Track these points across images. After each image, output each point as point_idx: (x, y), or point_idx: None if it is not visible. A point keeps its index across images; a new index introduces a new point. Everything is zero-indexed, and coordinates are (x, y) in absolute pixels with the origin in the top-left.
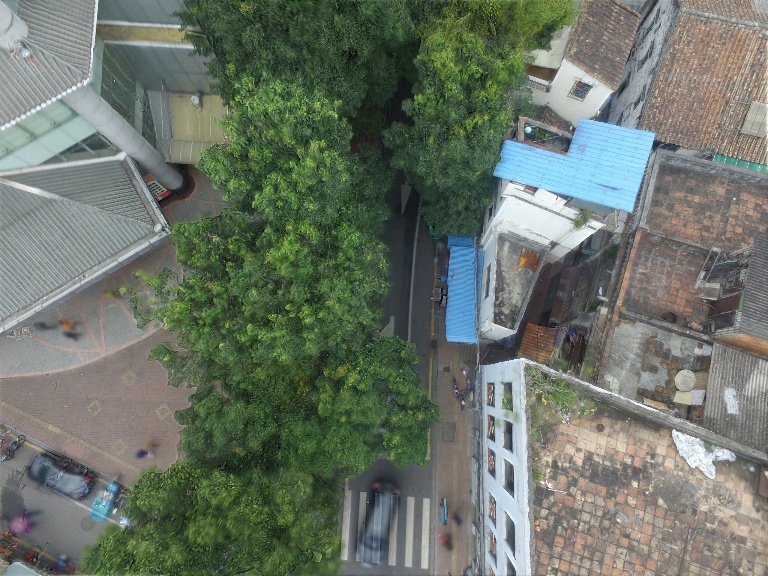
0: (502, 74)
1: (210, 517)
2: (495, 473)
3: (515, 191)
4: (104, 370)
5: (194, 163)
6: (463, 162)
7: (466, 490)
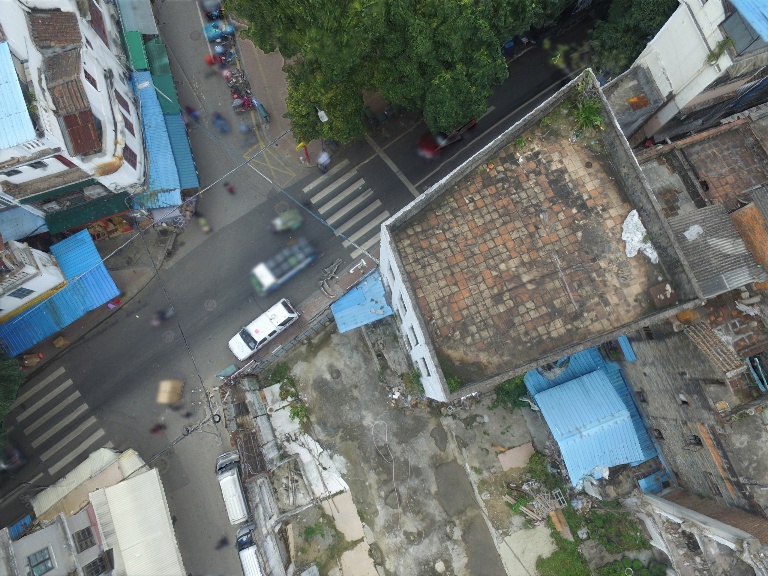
0: None
1: None
2: None
3: None
4: None
5: None
6: None
7: None
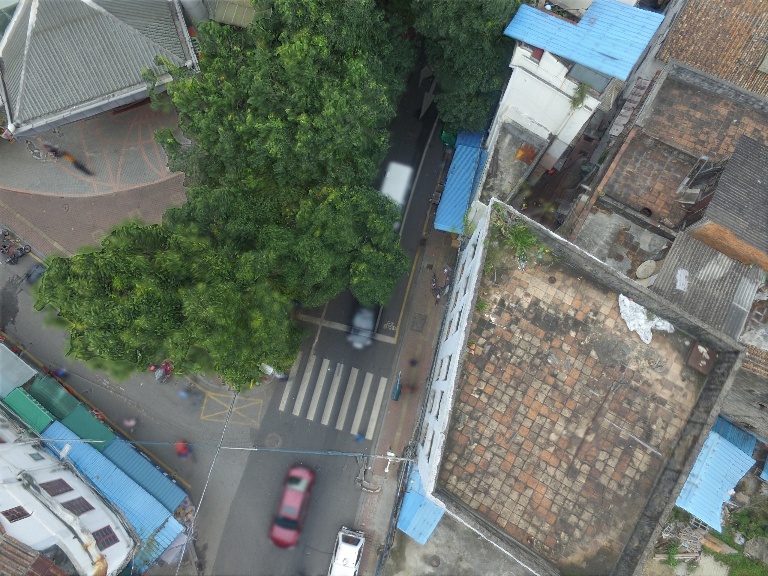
0: None
1: (178, 259)
2: (449, 332)
3: (522, 58)
4: (114, 204)
5: (235, 25)
6: (477, 7)
7: (423, 377)
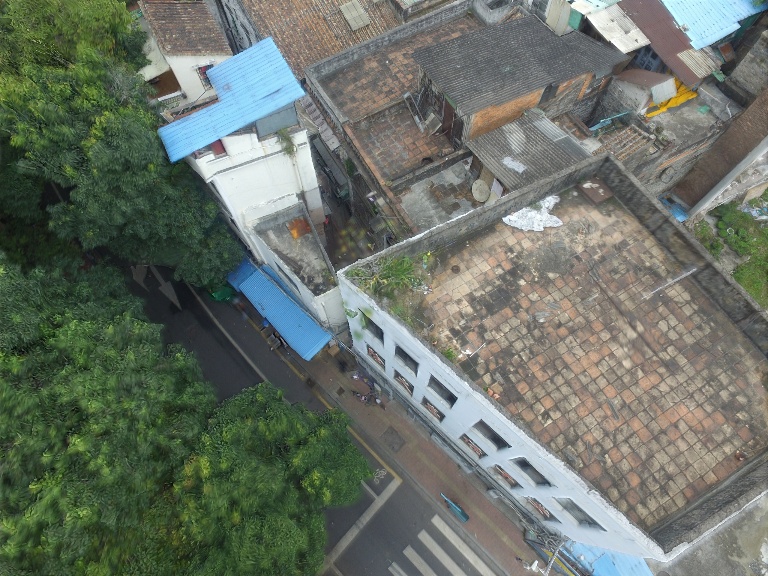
0: (85, 68)
1: None
2: None
3: (210, 165)
4: None
5: None
6: (123, 165)
7: (455, 470)
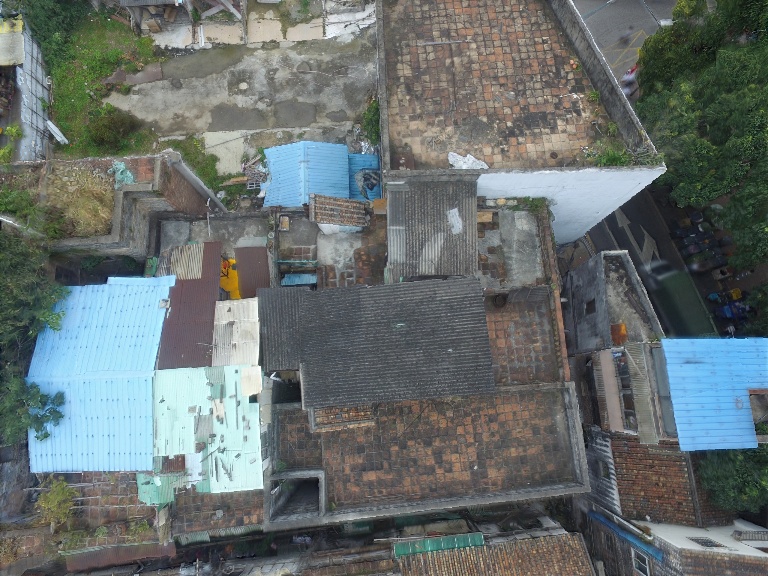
0: None
1: None
2: None
3: None
4: None
5: None
6: None
7: None
